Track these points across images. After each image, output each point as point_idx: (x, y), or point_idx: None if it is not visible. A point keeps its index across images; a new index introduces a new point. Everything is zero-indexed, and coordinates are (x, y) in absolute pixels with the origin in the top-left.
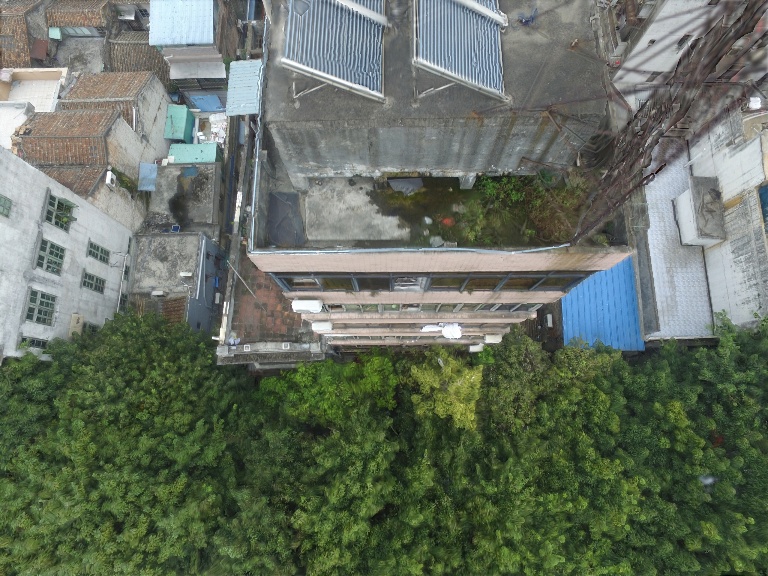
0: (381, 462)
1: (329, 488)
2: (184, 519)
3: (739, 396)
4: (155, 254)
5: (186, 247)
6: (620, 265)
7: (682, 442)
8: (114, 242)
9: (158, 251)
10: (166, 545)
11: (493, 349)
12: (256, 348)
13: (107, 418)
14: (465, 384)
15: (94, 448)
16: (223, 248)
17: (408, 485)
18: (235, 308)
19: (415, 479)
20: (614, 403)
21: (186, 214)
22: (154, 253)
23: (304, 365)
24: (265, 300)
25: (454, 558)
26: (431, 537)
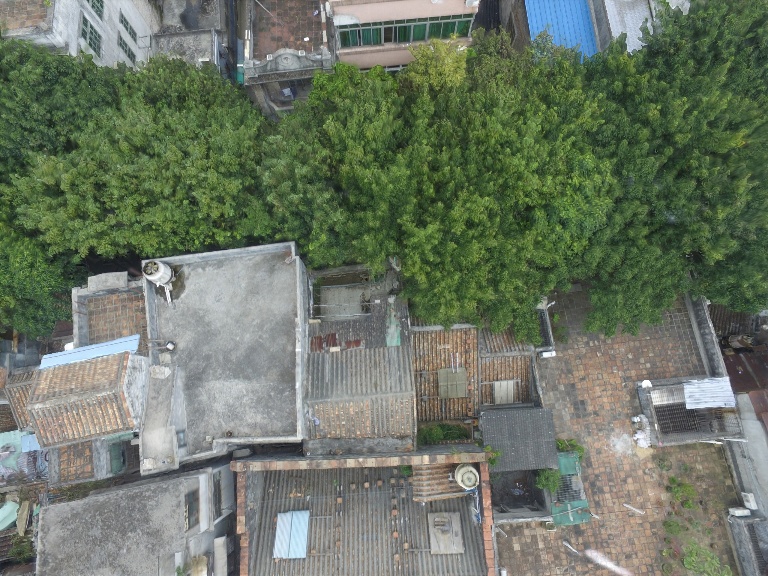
0: (390, 106)
1: (351, 117)
2: (236, 144)
3: (675, 46)
4: (174, 50)
5: (201, 43)
6: (577, 4)
7: (632, 85)
8: (139, 29)
9: (176, 48)
10: (225, 153)
11: (475, 49)
12: (277, 54)
13: (160, 101)
14: (453, 53)
15: (154, 111)
16: (231, 61)
17: (414, 123)
18: (254, 42)
19: (419, 108)
20: (577, 73)
21: (196, 24)
22: (173, 49)
23: (318, 73)
24: (279, 34)
25: (455, 150)
26: (436, 153)
